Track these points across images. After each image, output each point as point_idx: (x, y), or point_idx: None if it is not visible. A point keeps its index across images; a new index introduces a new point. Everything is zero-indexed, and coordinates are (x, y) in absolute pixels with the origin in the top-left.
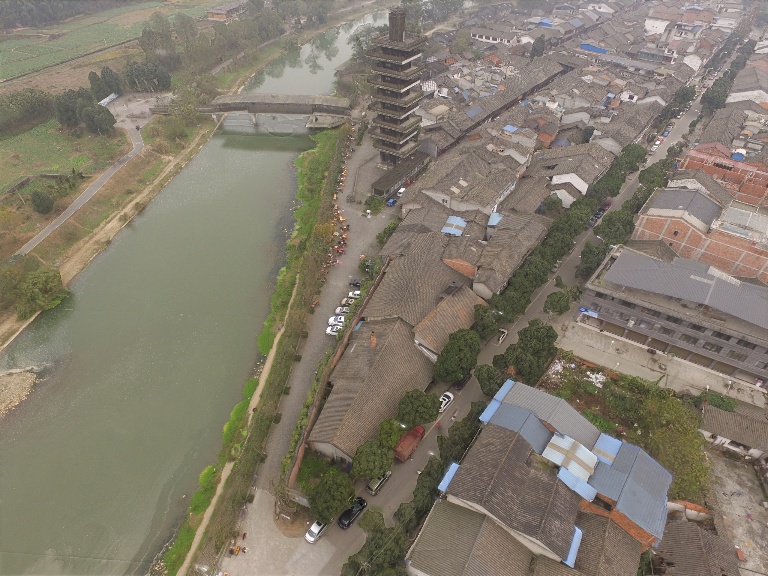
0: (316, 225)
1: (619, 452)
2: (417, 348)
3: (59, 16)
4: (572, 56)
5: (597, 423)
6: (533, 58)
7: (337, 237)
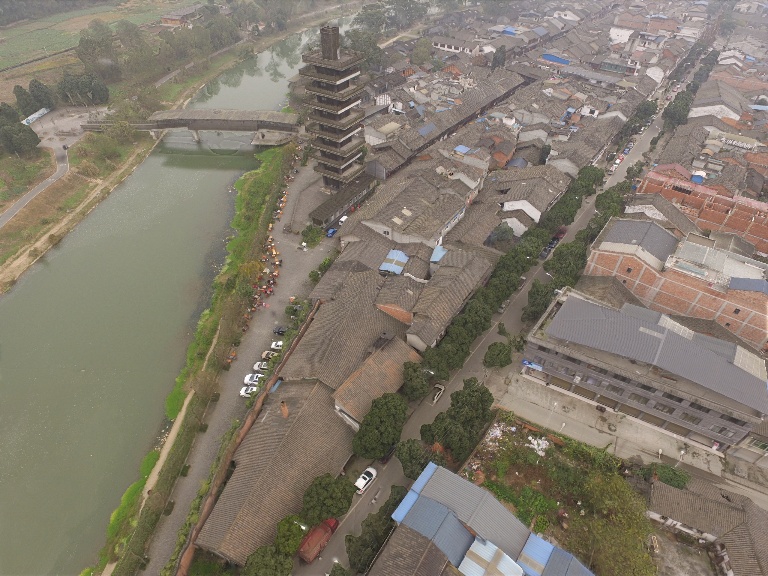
0: (240, 264)
1: (549, 561)
2: (337, 415)
3: None
4: (534, 67)
5: (536, 502)
6: (494, 69)
7: (267, 275)
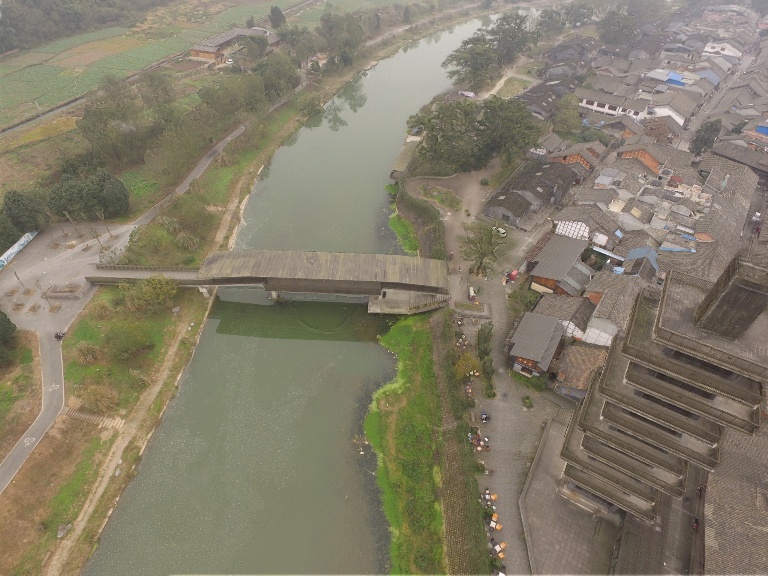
0: None
1: None
2: None
3: None
4: (759, 151)
5: None
6: (697, 152)
7: None
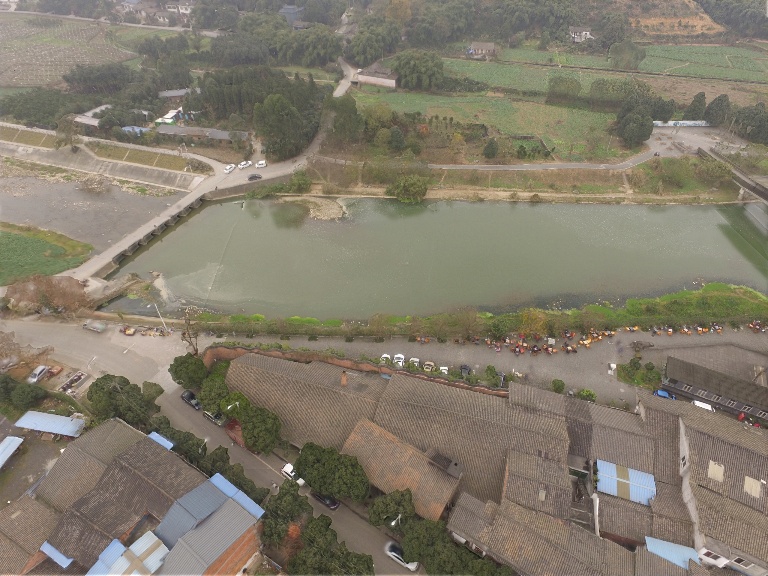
0: (532, 309)
1: None
2: None
3: None
4: None
5: None
6: None
7: (546, 343)
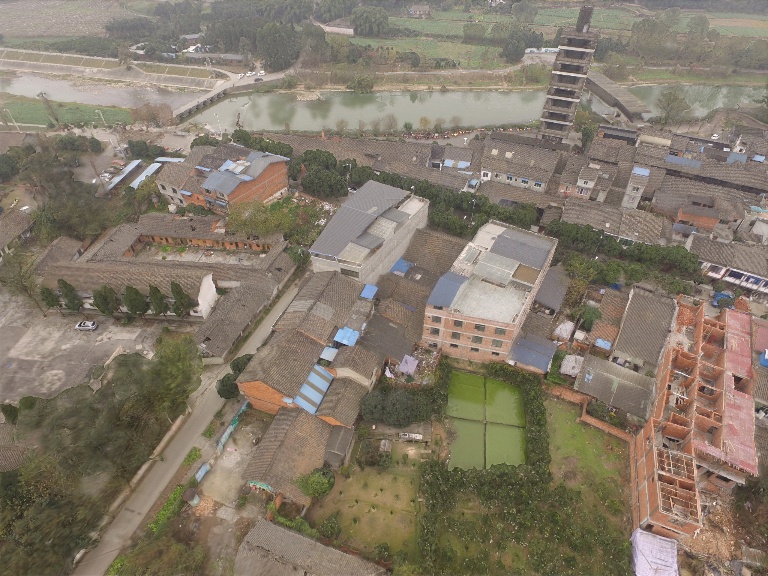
0: None
1: (241, 178)
2: None
3: (677, 5)
4: None
5: None
6: None
7: None
